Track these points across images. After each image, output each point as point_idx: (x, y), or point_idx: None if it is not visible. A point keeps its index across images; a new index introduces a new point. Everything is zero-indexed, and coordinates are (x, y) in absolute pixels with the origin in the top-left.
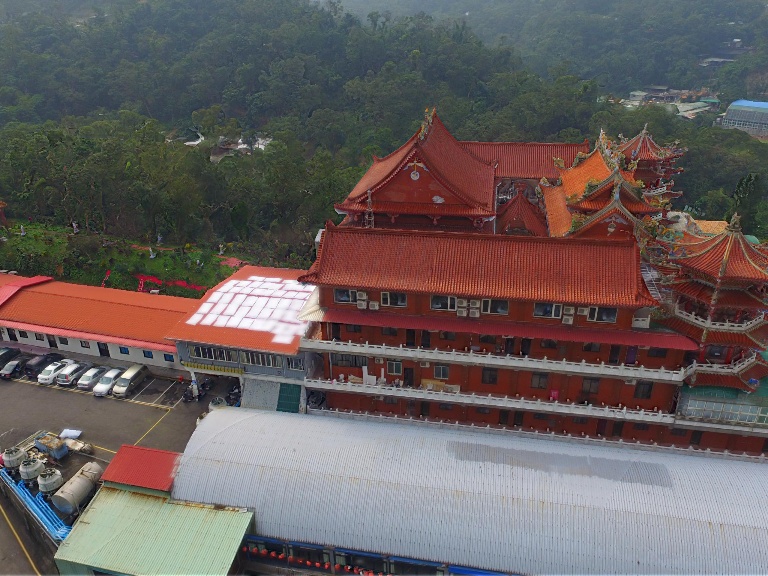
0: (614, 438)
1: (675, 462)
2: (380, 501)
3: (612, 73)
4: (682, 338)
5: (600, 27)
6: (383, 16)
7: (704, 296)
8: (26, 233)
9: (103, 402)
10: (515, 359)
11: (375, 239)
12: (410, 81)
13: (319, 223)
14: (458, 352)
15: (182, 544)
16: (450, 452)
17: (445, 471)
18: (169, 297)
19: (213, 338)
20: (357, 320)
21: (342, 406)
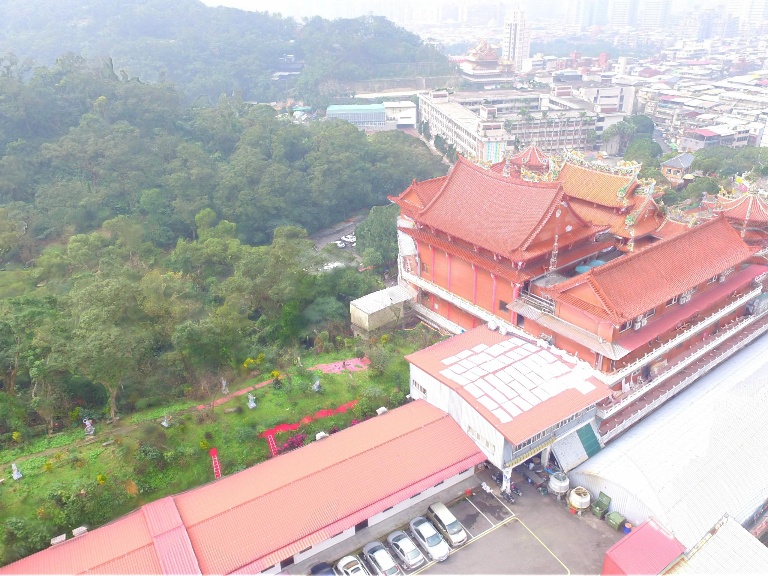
0: (728, 347)
1: None
2: (764, 449)
3: (209, 95)
4: (757, 266)
5: (175, 52)
6: (6, 59)
7: (766, 236)
8: (19, 472)
9: (458, 560)
10: (709, 319)
11: (620, 270)
12: (128, 133)
13: (310, 300)
14: (687, 331)
15: (740, 572)
16: (743, 396)
17: (761, 408)
18: (350, 431)
19: (548, 419)
20: (643, 339)
21: (604, 424)
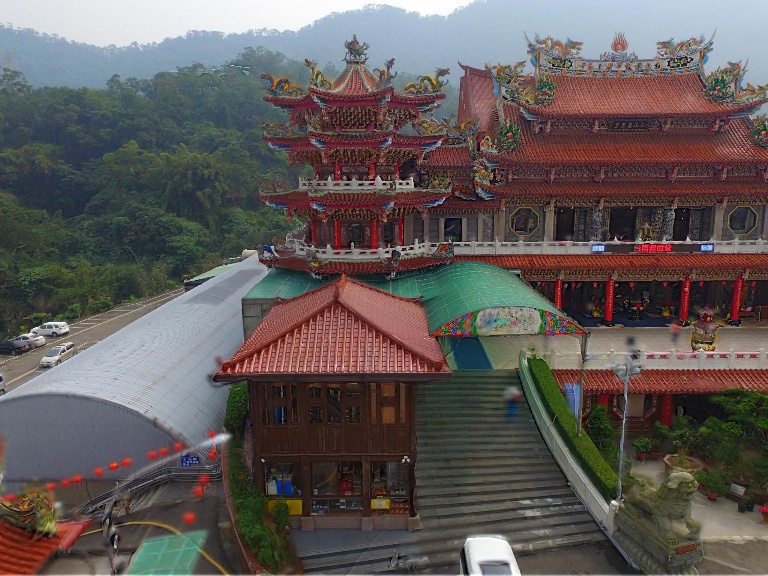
0: None
1: (221, 310)
2: None
3: None
4: None
5: None
6: None
7: None
8: None
9: None
10: None
11: None
12: None
13: None
14: None
15: None
16: None
17: None
18: None
19: None
20: None
21: None
